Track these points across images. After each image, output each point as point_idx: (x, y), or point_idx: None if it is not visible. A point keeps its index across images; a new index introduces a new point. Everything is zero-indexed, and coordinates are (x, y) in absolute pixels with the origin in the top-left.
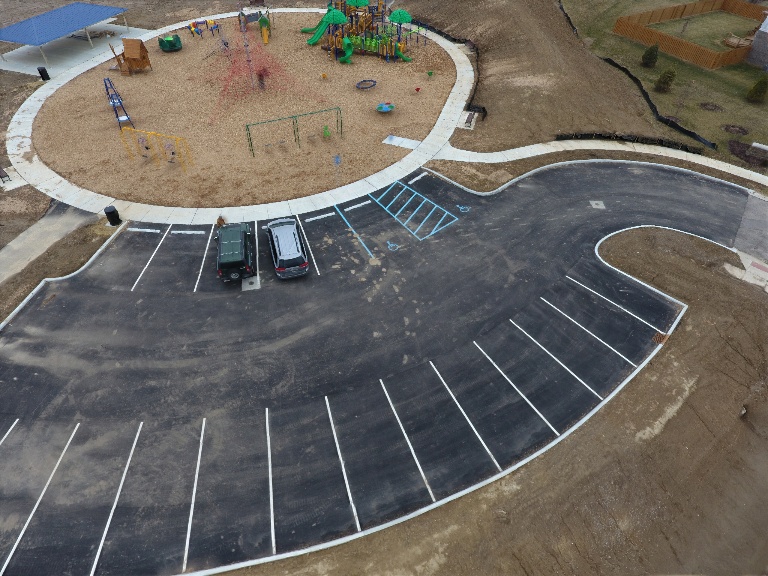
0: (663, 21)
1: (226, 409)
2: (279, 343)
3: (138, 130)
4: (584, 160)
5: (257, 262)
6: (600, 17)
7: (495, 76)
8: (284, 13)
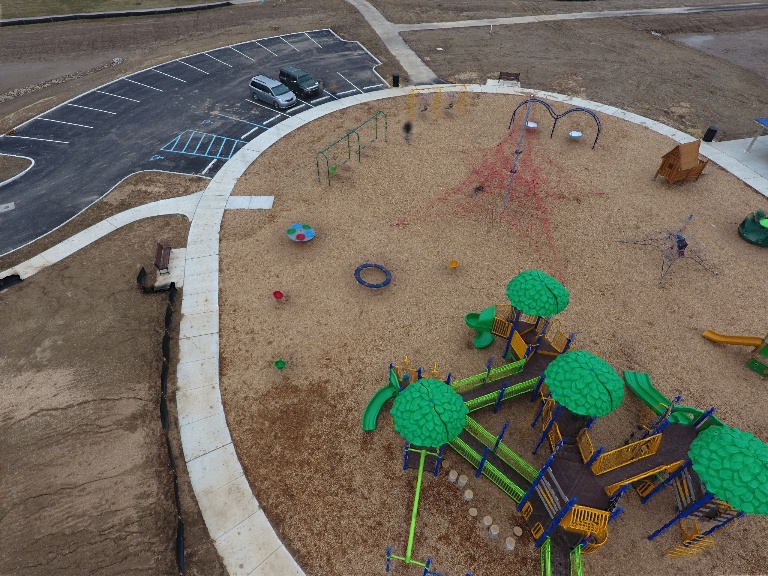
0: None
1: None
2: (244, 78)
3: (452, 86)
4: None
5: None
6: None
7: (119, 415)
8: None
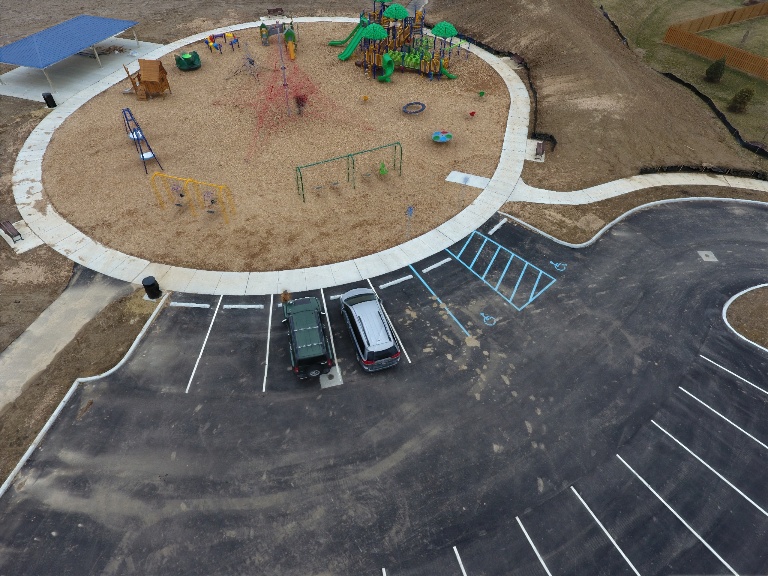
0: (712, 28)
1: (332, 572)
2: (381, 466)
3: None
4: (677, 199)
5: (333, 346)
6: (644, 24)
7: (554, 96)
8: (306, 23)
